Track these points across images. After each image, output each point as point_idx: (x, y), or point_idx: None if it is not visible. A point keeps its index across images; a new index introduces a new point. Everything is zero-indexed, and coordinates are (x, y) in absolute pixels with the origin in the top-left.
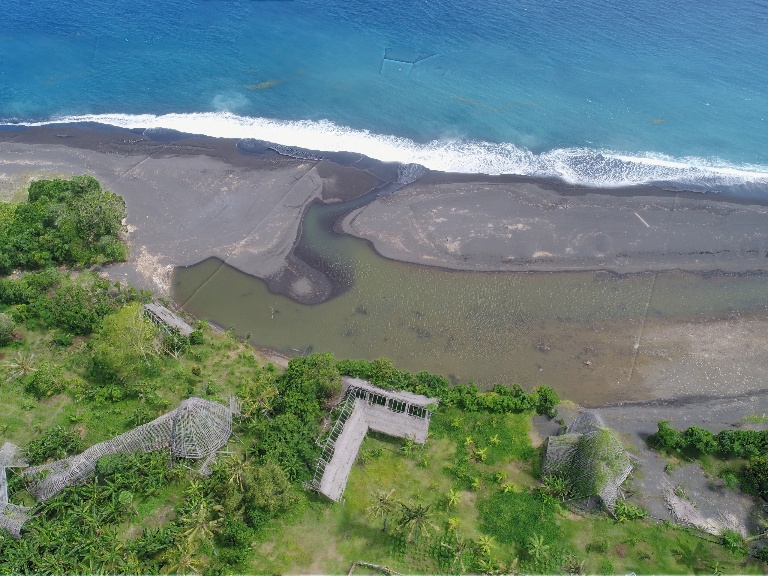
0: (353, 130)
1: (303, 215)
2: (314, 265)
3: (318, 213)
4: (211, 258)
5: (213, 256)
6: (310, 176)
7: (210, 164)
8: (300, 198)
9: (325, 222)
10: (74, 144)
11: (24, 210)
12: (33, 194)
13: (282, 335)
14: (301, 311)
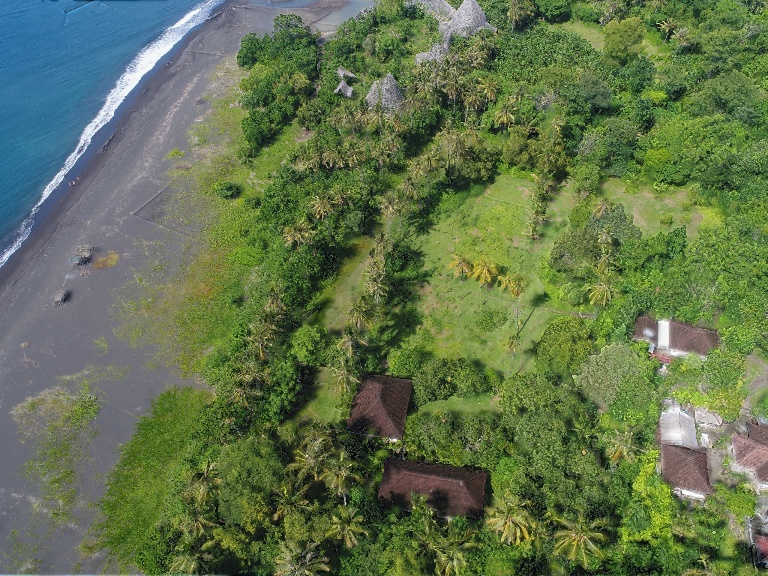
0: (194, 3)
1: (280, 7)
2: (321, 3)
3: (278, 5)
4: (311, 25)
5: (310, 24)
6: (246, 5)
7: (218, 32)
8: (266, 7)
9: (287, 3)
10: (165, 81)
11: (277, 47)
12: (250, 59)
13: (367, 6)
14: (352, 4)
